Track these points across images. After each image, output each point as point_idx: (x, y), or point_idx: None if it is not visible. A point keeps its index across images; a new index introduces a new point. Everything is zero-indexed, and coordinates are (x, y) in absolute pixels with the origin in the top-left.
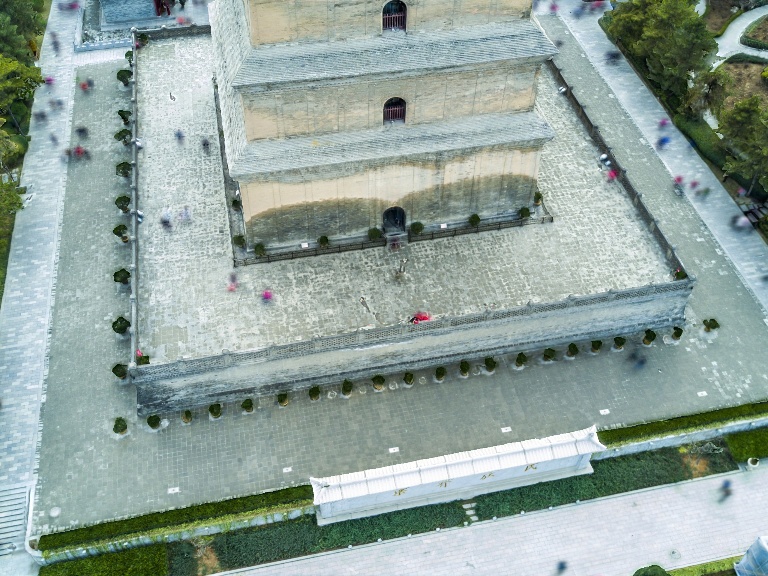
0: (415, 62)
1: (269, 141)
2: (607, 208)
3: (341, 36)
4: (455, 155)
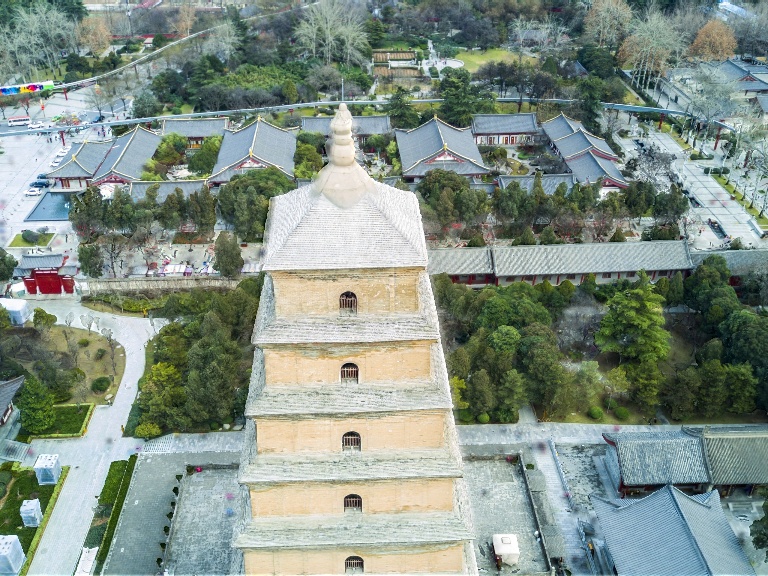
0: None
1: None
2: None
3: None
4: None
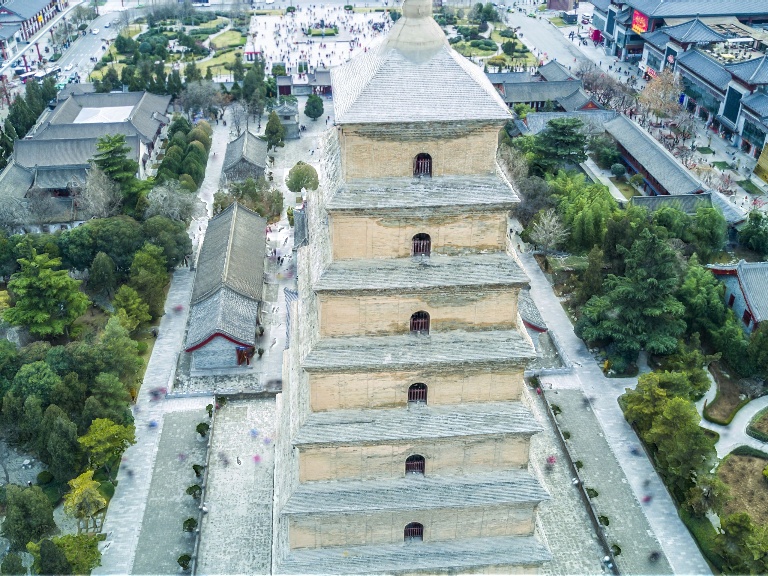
0: (430, 501)
1: (308, 550)
2: None
3: (372, 477)
4: (465, 568)
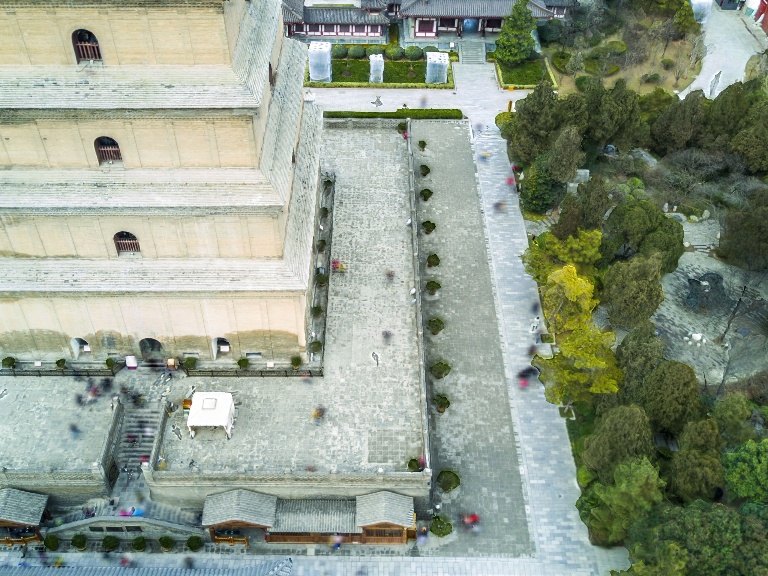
0: None
1: None
2: None
3: None
4: None
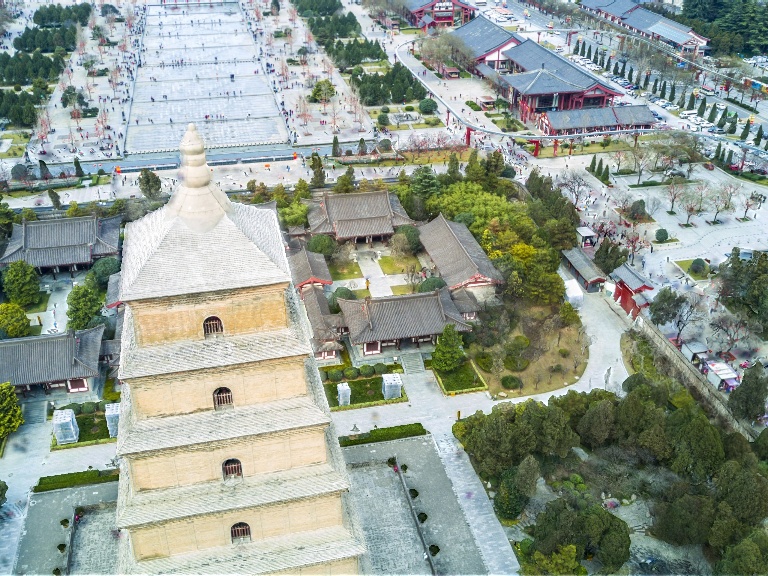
0: None
1: None
2: (91, 572)
3: None
4: None
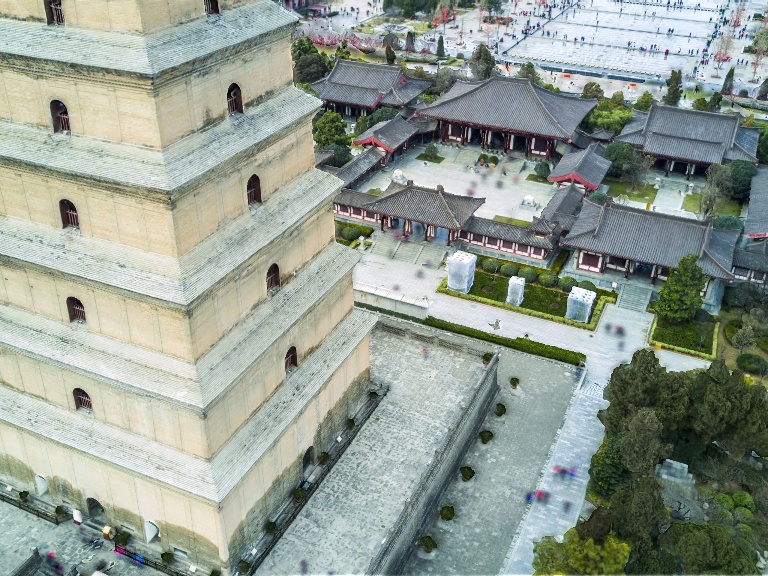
0: None
1: None
2: None
3: None
4: None
